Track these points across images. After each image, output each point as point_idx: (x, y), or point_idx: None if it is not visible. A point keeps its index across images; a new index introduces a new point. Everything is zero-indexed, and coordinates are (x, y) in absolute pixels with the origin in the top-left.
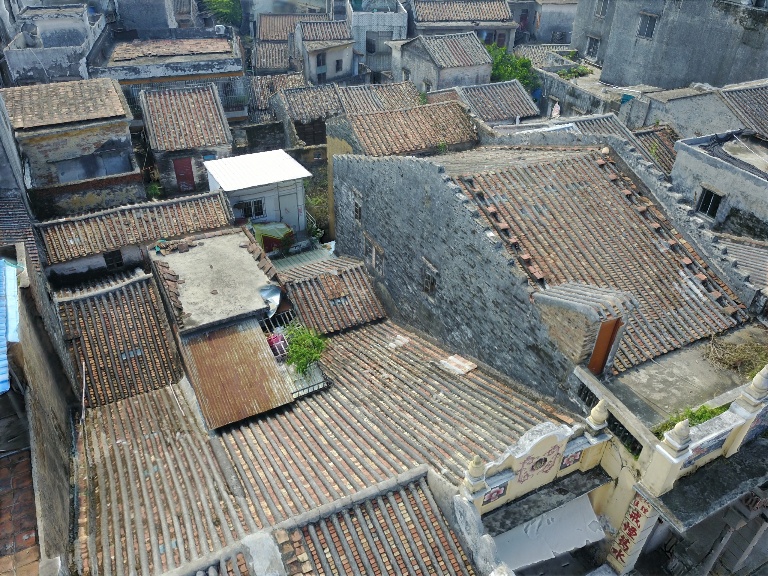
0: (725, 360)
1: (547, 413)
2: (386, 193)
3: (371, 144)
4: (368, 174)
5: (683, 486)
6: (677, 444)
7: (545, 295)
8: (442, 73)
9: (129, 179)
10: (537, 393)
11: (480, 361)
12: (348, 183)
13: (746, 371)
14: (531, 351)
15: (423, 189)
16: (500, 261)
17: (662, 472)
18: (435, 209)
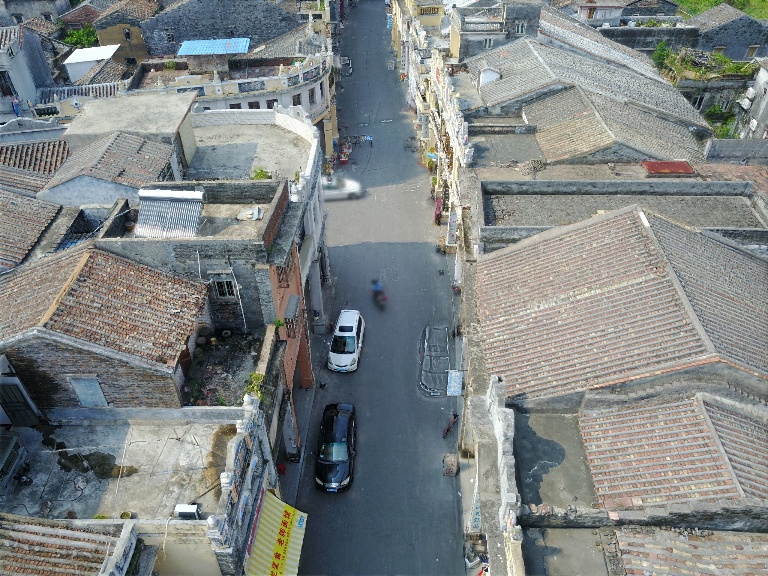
0: (308, 8)
1: (297, 31)
2: (192, 15)
3: (141, 16)
4: (176, 15)
5: (331, 19)
6: (328, 4)
7: (280, 1)
8: (56, 4)
9: (59, 76)
10: (289, 32)
11: (265, 42)
12: (159, 29)
13: (313, 8)
14: (282, 21)
15: (216, 0)
16: (261, 2)
17: (329, 14)
18: (226, 4)
